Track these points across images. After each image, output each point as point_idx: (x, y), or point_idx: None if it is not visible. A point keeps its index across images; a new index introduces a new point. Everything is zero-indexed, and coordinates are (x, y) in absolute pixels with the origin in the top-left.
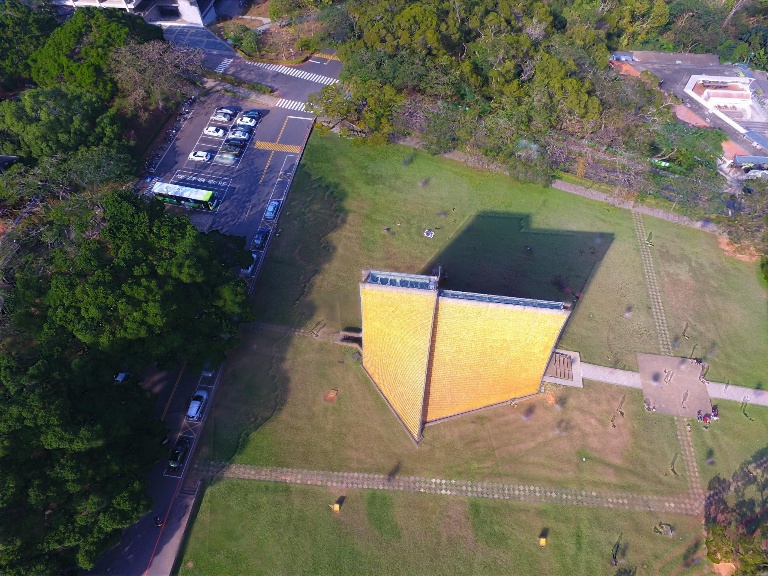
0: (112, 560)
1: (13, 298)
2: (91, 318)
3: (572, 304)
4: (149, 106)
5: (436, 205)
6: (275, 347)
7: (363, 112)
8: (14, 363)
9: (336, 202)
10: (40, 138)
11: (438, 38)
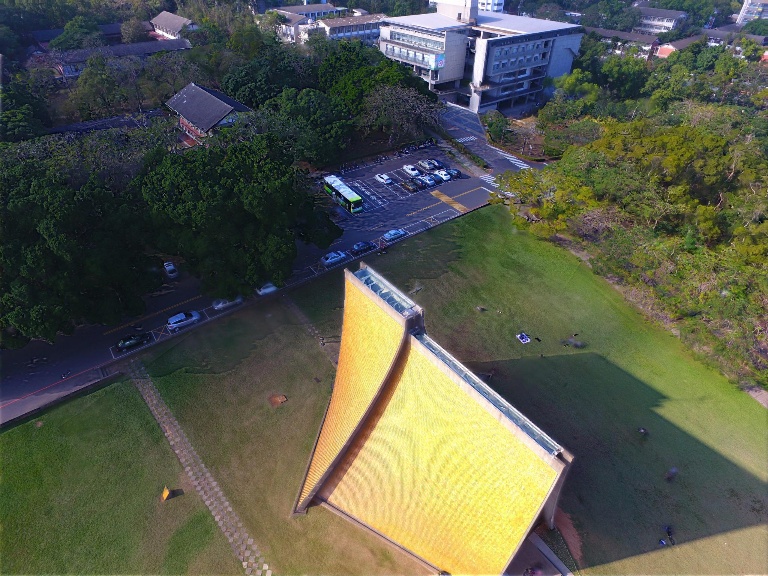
0: (18, 373)
1: (144, 153)
2: (163, 187)
3: (655, 542)
4: (373, 126)
5: (559, 320)
6: (282, 327)
7: (544, 199)
8: (97, 183)
9: (456, 261)
10: (288, 113)
11: (679, 166)
